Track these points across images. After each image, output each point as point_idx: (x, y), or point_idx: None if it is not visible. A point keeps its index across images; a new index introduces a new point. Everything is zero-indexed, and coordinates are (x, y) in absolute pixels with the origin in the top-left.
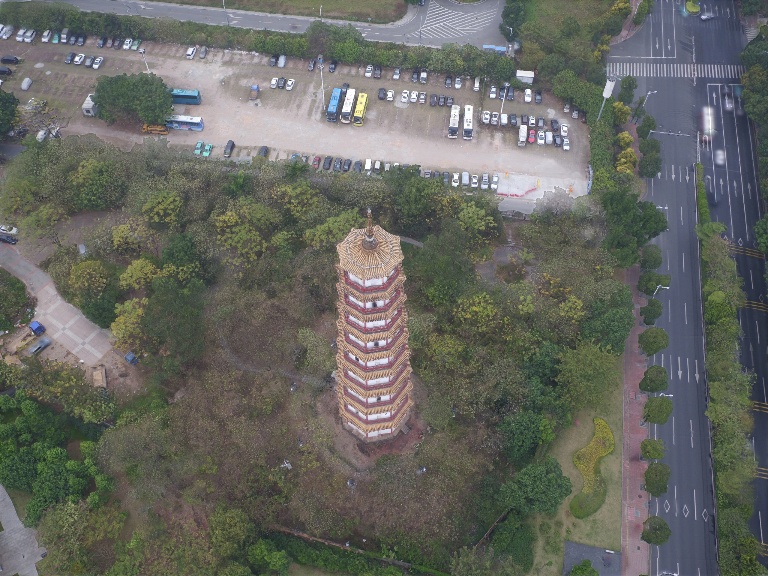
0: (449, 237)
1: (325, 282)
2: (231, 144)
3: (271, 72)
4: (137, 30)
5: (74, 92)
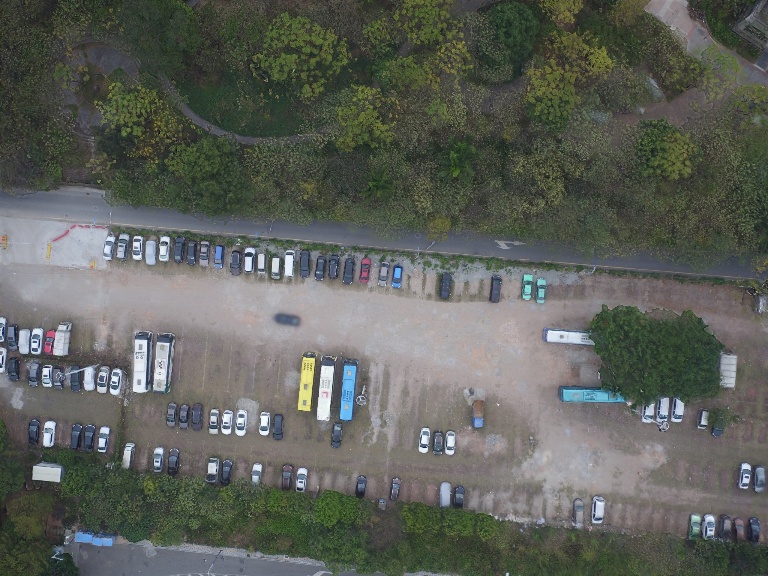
0: (141, 2)
1: (319, 1)
2: (493, 294)
3: (460, 471)
4: (699, 546)
5: (763, 406)
